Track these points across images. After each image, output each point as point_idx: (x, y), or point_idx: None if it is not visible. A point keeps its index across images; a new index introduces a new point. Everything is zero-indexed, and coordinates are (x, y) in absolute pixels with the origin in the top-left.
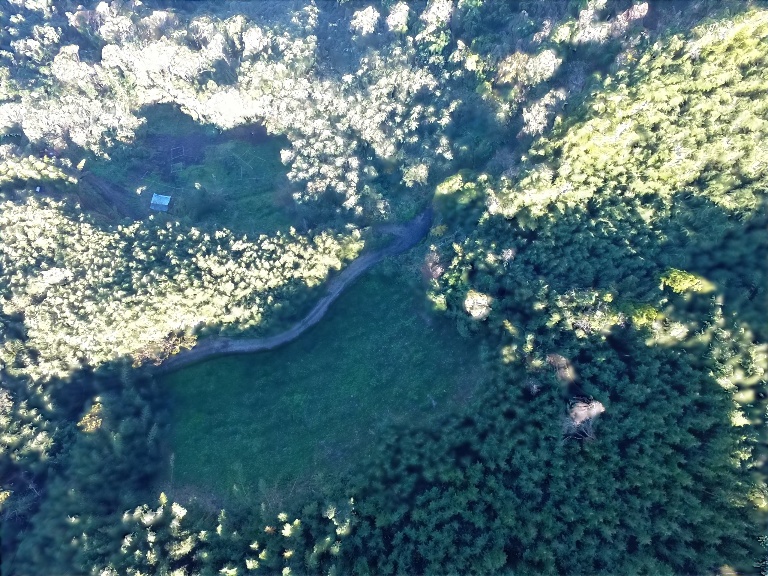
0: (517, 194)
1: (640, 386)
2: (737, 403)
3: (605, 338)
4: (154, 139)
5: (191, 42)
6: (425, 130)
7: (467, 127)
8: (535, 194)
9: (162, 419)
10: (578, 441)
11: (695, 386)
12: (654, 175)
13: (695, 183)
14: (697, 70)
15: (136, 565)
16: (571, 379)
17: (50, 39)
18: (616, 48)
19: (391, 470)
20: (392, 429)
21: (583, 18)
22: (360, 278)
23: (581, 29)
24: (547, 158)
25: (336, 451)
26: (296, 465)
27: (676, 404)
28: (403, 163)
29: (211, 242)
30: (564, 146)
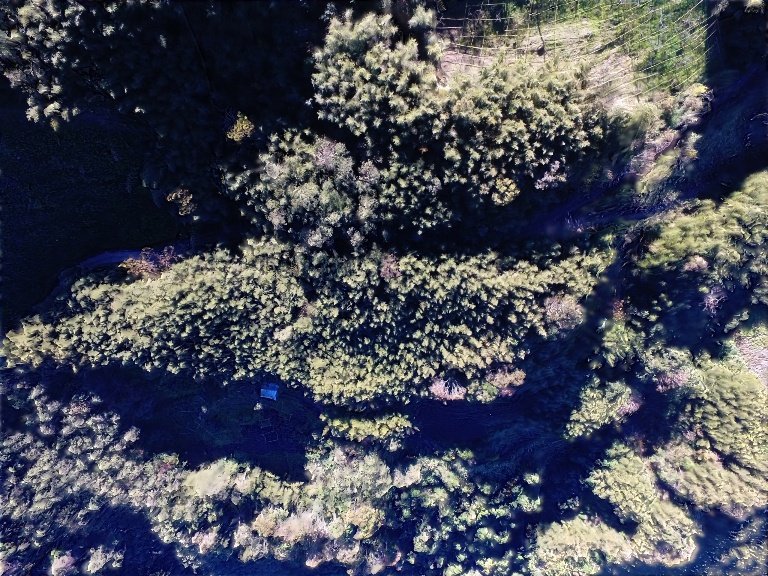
0: None
1: None
2: None
3: None
4: (300, 449)
5: None
6: None
7: None
8: None
9: None
10: None
11: None
12: None
13: None
14: None
15: (36, 63)
16: None
17: None
18: None
19: None
20: None
21: None
22: None
23: None
24: None
25: None
26: None
27: None
28: None
29: None
30: None
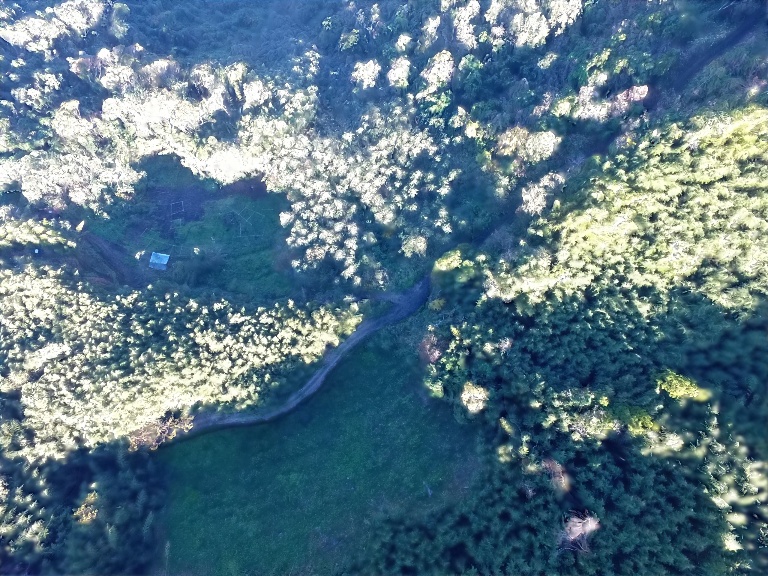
0: (515, 280)
1: (635, 498)
2: (731, 525)
3: (601, 443)
4: (154, 192)
5: (192, 89)
6: (424, 198)
7: (466, 195)
8: (533, 283)
9: (158, 501)
10: (572, 552)
11: (690, 501)
12: (652, 267)
13: (692, 277)
14: (696, 162)
15: None
16: (566, 489)
17: (51, 86)
18: (615, 126)
19: (386, 570)
20: (387, 525)
21: (583, 94)
22: (358, 348)
23: (581, 105)
24: (545, 240)
25: (331, 540)
26: (291, 553)
27: (670, 521)
28: (402, 230)
29: (209, 315)
30: (562, 231)
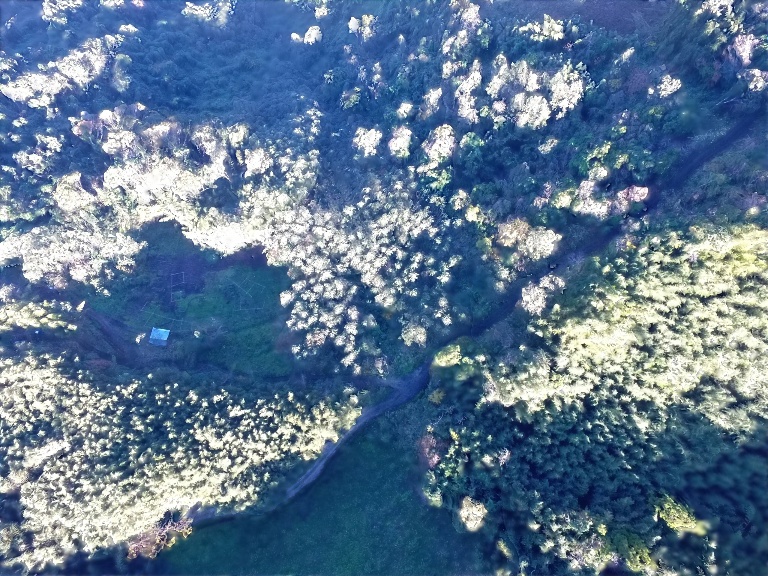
0: (514, 386)
1: None
2: None
3: (599, 573)
4: (154, 261)
5: (193, 149)
6: (425, 282)
7: (466, 280)
8: (532, 393)
9: None
10: None
11: None
12: (650, 380)
13: (691, 392)
14: (695, 275)
15: None
16: None
17: (52, 149)
18: (615, 223)
19: None
20: None
21: (583, 189)
22: (357, 436)
23: (581, 199)
24: (545, 341)
25: None
26: None
27: None
28: (402, 315)
29: (209, 407)
30: (562, 336)
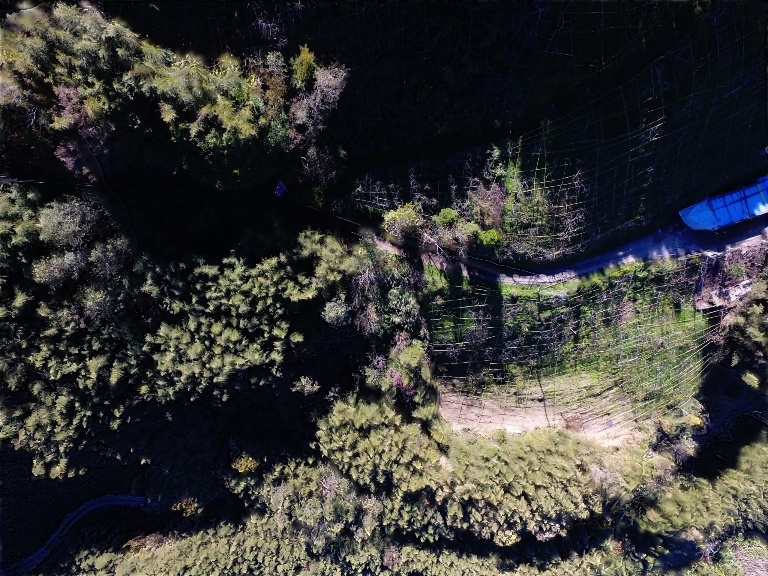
0: None
1: None
2: None
3: None
4: None
5: None
6: None
7: None
8: None
9: None
10: None
11: None
12: None
13: None
14: None
15: None
16: None
17: None
18: None
19: None
20: None
21: None
22: None
23: None
24: None
25: None
26: None
27: None
28: None
29: None
30: None
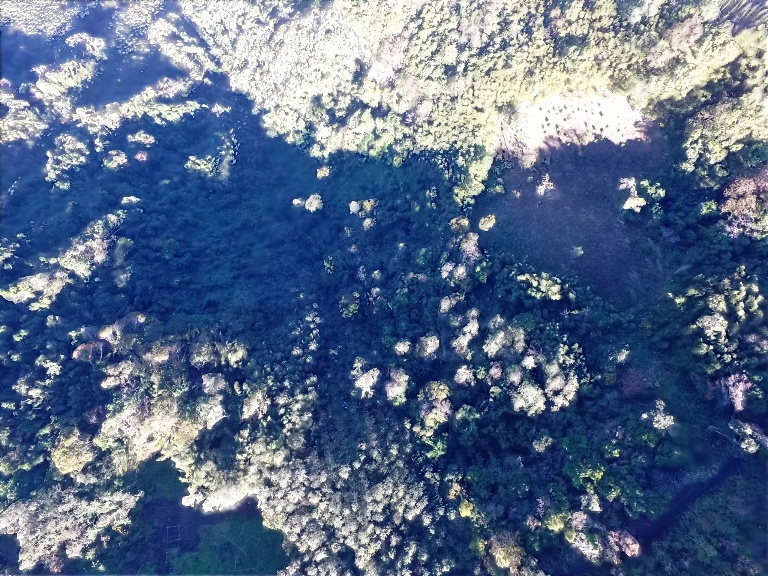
0: None
1: None
2: None
3: None
4: (150, 509)
5: None
6: None
7: None
8: None
9: None
10: None
11: None
12: None
13: None
14: None
15: None
16: None
17: (52, 374)
18: None
19: None
20: None
21: (576, 520)
22: None
23: (574, 530)
24: None
25: None
26: None
27: None
28: None
29: None
30: None
